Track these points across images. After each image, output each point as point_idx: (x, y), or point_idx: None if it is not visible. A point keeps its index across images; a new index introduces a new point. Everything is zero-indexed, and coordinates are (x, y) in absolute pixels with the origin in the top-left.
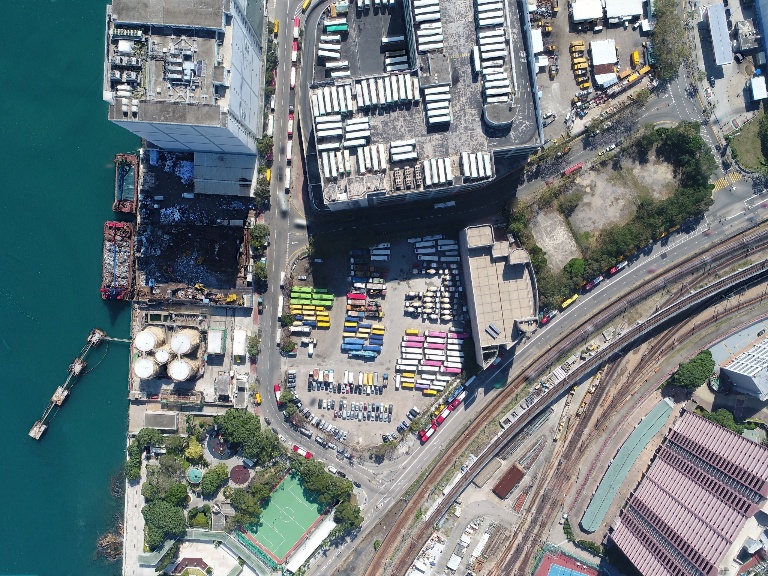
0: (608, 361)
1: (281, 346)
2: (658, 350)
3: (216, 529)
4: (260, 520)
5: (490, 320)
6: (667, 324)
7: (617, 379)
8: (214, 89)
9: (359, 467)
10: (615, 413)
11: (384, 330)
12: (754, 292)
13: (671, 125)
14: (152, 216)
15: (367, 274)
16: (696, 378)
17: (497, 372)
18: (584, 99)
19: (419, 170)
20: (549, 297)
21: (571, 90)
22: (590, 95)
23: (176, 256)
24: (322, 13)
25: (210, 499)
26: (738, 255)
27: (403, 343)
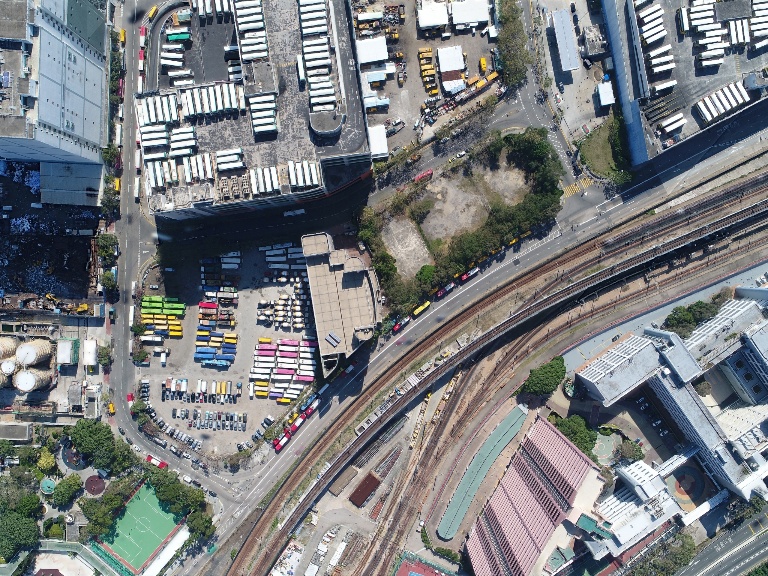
0: (462, 368)
1: (134, 356)
2: (512, 356)
3: (70, 540)
4: (116, 530)
5: (330, 328)
6: (521, 330)
7: (472, 386)
8: (22, 100)
9: (214, 476)
10: (471, 420)
11: (237, 339)
12: (608, 298)
13: (521, 131)
14: (2, 226)
15: (218, 283)
16: (545, 384)
17: (351, 380)
18: (432, 106)
19: (246, 179)
20: (397, 304)
21: (420, 97)
22: (439, 102)
23: (25, 266)
24: (165, 22)
25: (65, 510)
26: (590, 261)
27: (255, 352)
